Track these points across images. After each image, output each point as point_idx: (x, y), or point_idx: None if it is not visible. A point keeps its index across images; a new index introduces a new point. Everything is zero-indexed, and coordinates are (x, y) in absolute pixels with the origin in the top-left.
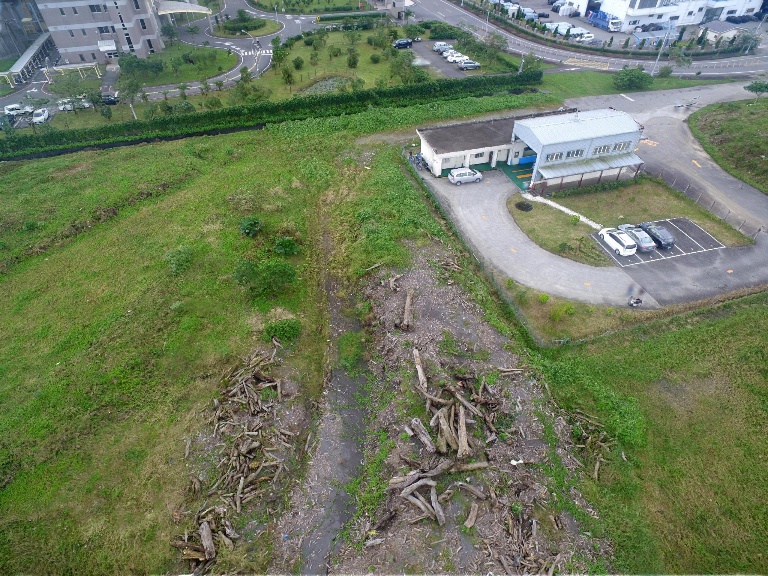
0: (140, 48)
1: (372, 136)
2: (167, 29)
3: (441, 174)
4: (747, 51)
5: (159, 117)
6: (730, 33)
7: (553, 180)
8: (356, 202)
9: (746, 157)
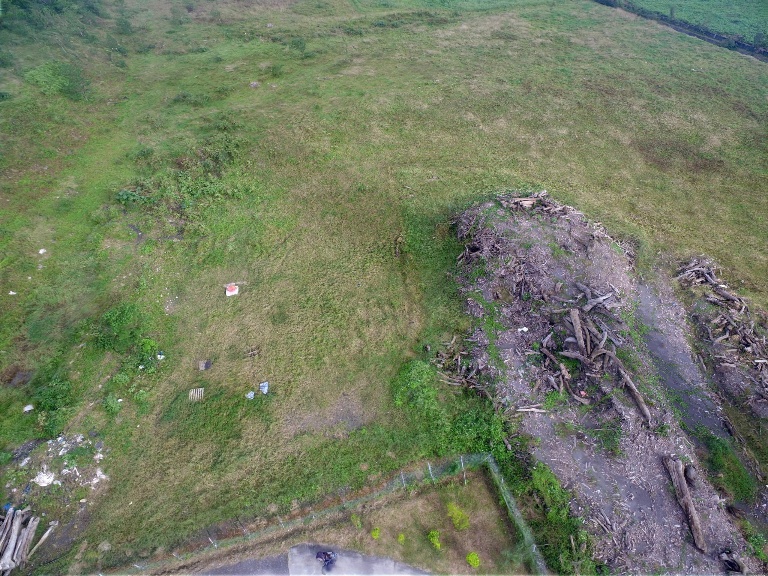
0: None
1: None
2: None
3: None
4: None
5: None
6: None
7: None
8: None
9: None
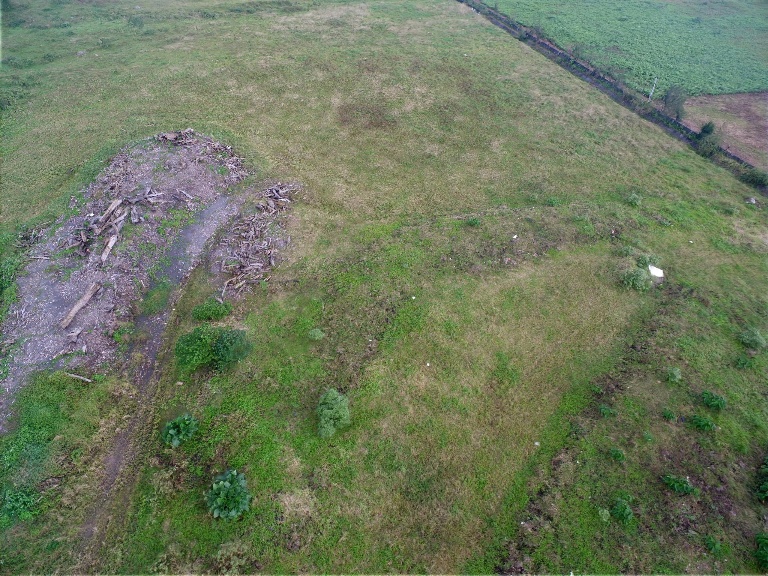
0: None
1: None
2: None
3: None
4: None
5: None
6: None
7: None
8: (5, 571)
9: None
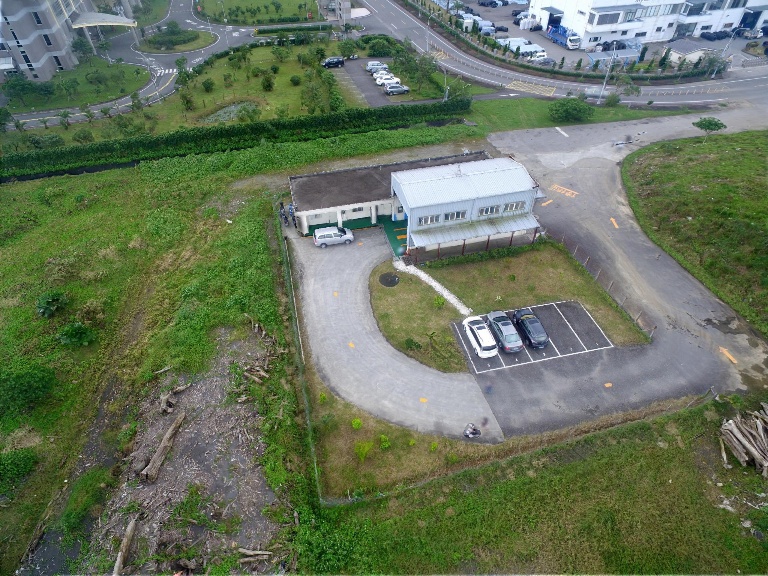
0: (40, 67)
1: (253, 178)
2: (78, 44)
3: (309, 232)
4: (713, 75)
5: (15, 153)
6: (696, 54)
7: (433, 244)
8: (191, 270)
9: (671, 217)
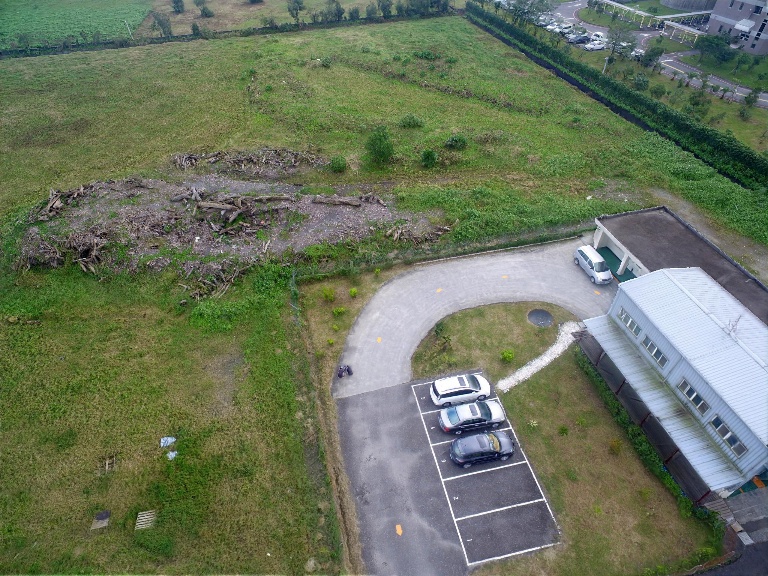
0: (765, 39)
1: (681, 201)
2: None
3: (597, 249)
4: None
5: (610, 77)
6: None
7: None
8: None
9: None
